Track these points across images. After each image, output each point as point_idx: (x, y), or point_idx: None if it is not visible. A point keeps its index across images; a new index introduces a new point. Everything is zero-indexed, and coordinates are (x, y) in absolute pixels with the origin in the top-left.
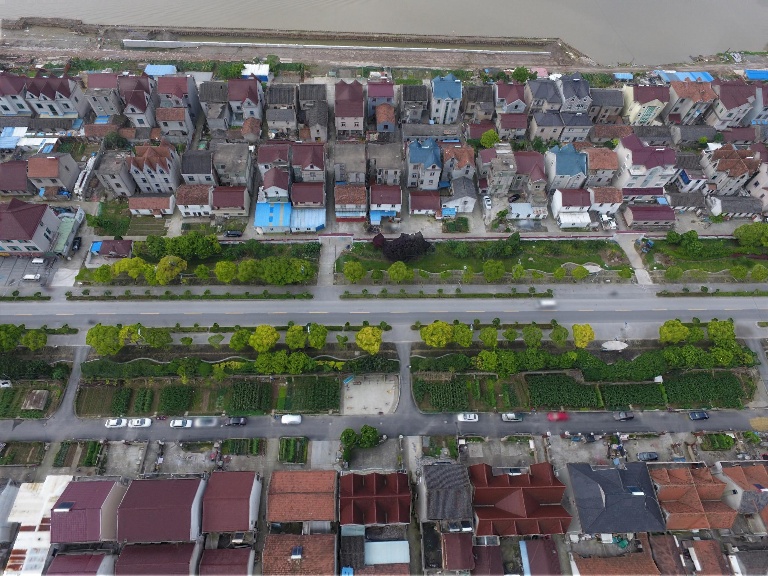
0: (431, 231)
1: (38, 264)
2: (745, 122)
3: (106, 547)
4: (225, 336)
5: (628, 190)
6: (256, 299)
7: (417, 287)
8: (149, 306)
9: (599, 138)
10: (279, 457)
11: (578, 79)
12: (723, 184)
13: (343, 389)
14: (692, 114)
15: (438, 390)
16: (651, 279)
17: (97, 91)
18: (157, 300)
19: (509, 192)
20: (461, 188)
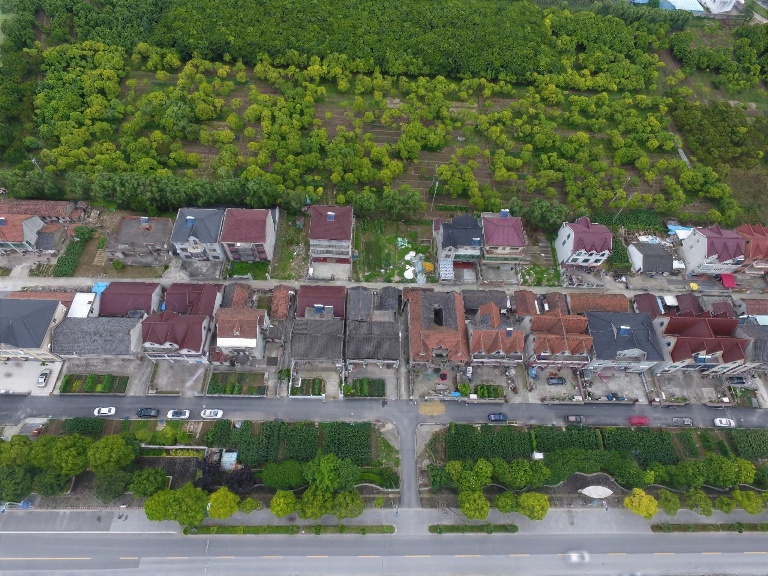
0: None
1: None
2: None
3: None
4: None
5: None
6: None
7: None
8: None
9: None
10: None
11: None
12: None
13: None
14: None
15: (767, 448)
16: None
17: None
18: None
19: None
20: None
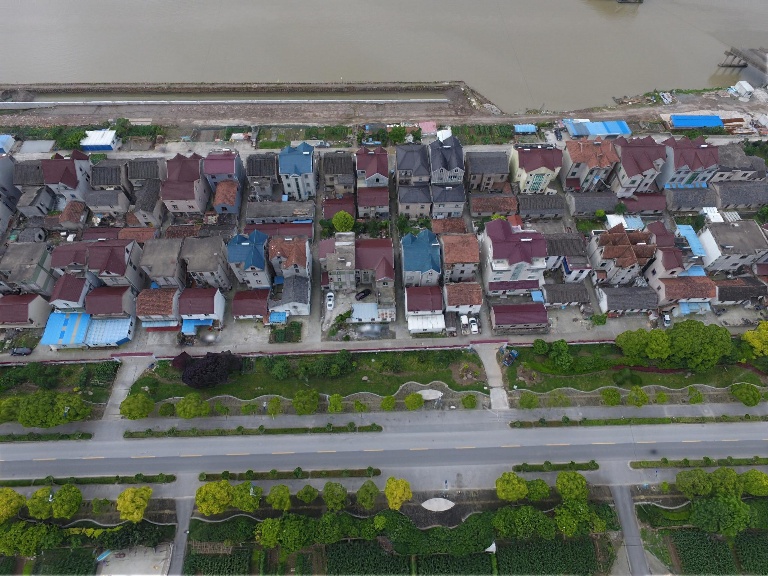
0: (255, 341)
1: None
2: (659, 184)
3: None
4: None
5: (496, 284)
6: (23, 441)
7: (220, 420)
8: None
9: (478, 212)
10: None
11: (449, 146)
12: (613, 273)
13: (101, 564)
14: (591, 180)
15: (212, 568)
16: (508, 402)
17: None
18: None
19: (359, 286)
20: (289, 290)
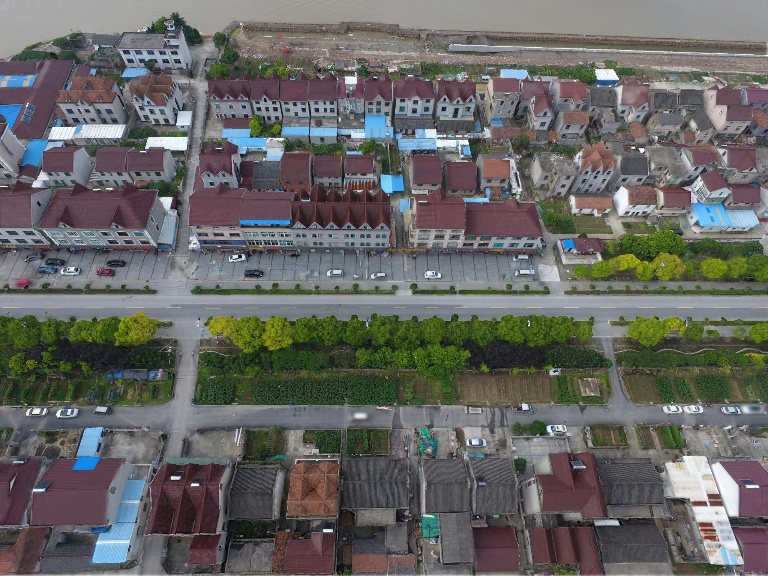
0: None
1: (522, 260)
2: None
3: (754, 522)
4: (726, 329)
5: None
6: (734, 295)
7: None
8: (641, 300)
9: None
10: None
11: None
12: None
13: None
14: None
15: None
16: None
17: (506, 95)
18: (645, 295)
19: None
20: None
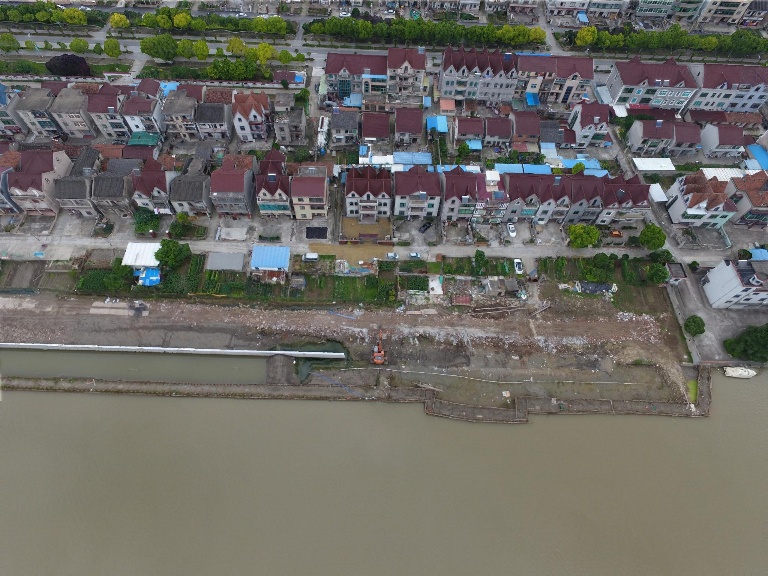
0: None
1: None
2: None
3: None
4: None
5: None
6: None
7: None
8: None
9: None
10: (192, 3)
11: None
12: None
13: None
14: None
15: None
16: None
17: (313, 170)
18: None
19: None
20: None
